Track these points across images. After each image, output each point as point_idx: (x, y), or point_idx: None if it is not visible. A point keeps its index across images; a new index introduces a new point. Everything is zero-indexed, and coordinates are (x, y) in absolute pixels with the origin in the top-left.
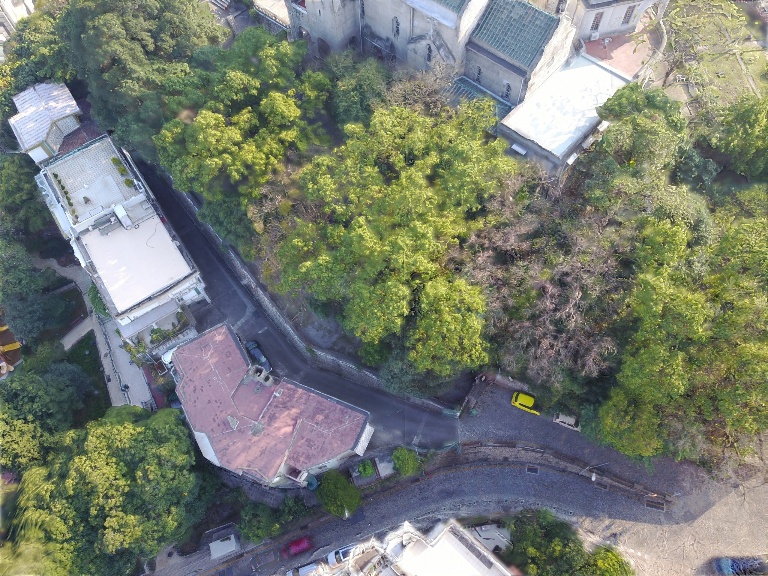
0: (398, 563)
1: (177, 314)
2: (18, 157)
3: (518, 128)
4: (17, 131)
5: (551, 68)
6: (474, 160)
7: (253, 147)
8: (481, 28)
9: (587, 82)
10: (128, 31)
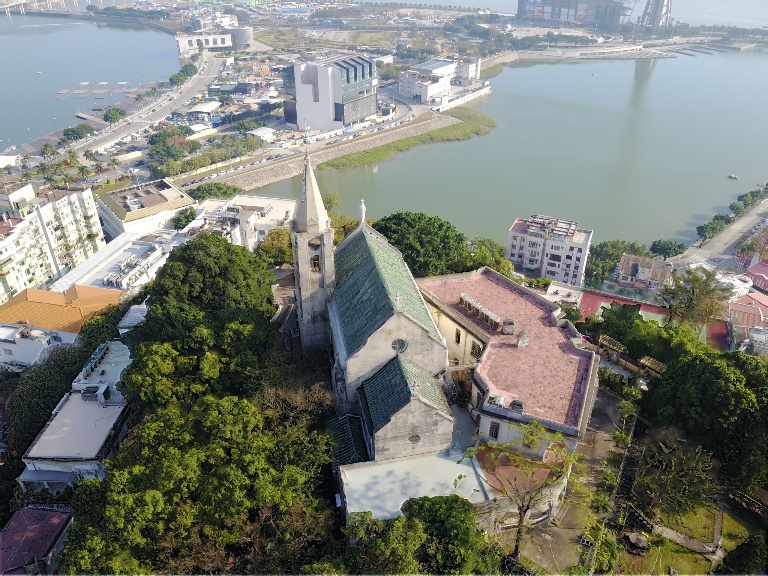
0: None
1: (67, 486)
2: (118, 331)
3: (353, 481)
4: (127, 314)
5: (419, 446)
6: (252, 473)
7: (170, 383)
8: (372, 380)
9: (451, 479)
10: (186, 278)
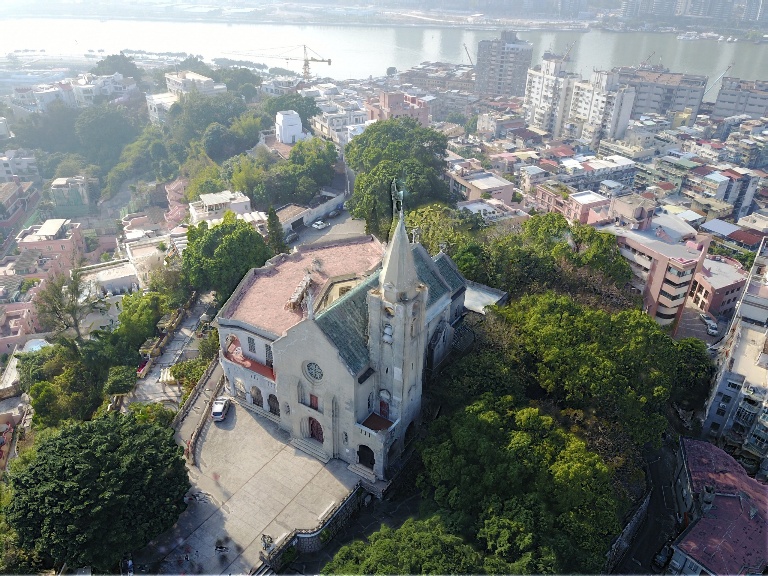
0: (767, 389)
1: None
2: None
3: (482, 312)
4: None
5: None
6: None
7: None
8: None
9: None
10: None
